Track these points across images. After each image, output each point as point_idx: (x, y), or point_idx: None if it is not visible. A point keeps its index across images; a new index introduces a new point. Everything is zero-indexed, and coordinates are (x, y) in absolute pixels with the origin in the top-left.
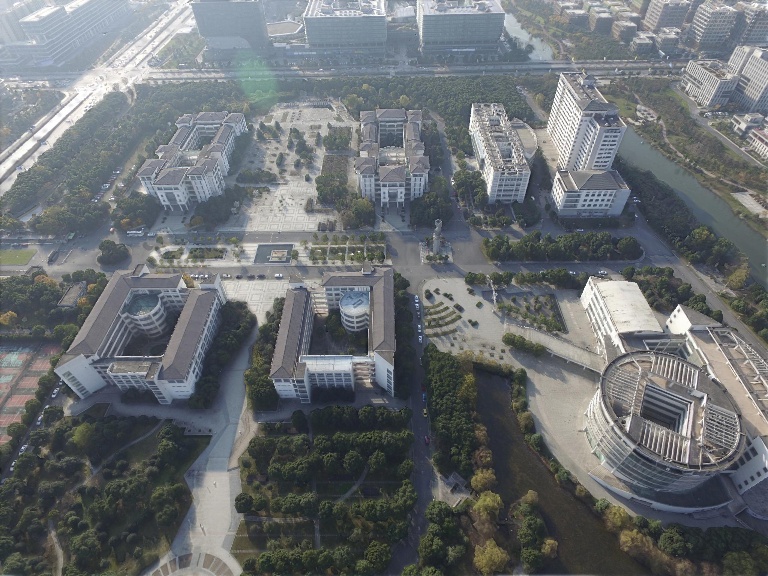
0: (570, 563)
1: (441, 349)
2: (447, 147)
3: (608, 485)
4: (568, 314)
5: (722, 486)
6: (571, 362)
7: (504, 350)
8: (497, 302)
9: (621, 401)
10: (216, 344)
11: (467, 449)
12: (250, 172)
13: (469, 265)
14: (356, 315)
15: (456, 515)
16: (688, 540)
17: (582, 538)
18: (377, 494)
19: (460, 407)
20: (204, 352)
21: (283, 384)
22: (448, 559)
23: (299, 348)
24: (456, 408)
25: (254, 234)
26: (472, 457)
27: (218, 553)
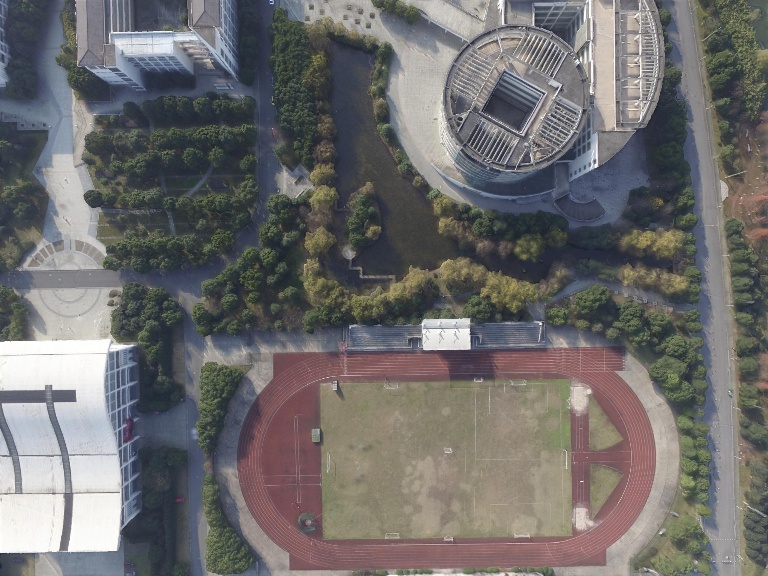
0: (394, 241)
1: (297, 14)
2: None
3: (445, 175)
4: None
5: (552, 176)
6: (449, 31)
7: (373, 14)
8: None
9: (464, 95)
10: (11, 13)
11: (308, 144)
12: None
13: None
14: None
15: (295, 206)
16: (495, 225)
17: (410, 221)
18: (223, 187)
19: (303, 97)
20: (1, 25)
21: (102, 71)
22: (282, 243)
23: (107, 21)
24: (299, 98)
25: None
26: (314, 151)
27: (86, 239)
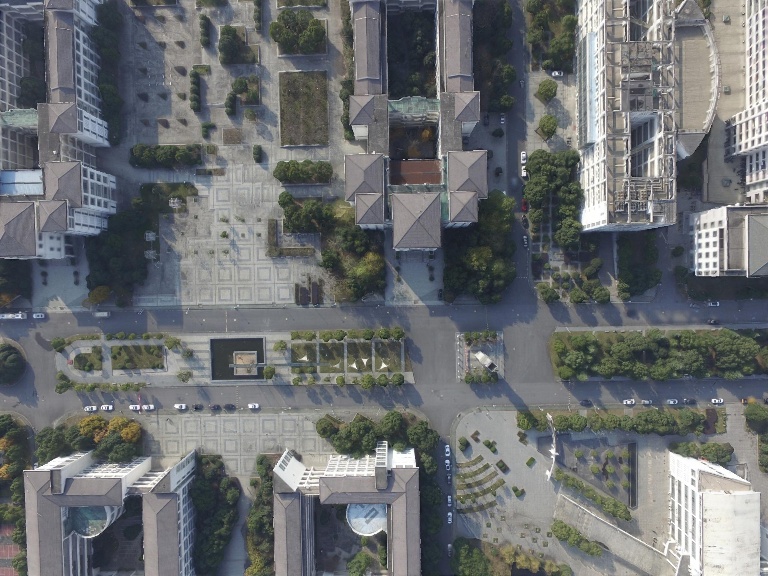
0: None
1: (474, 531)
2: (523, 38)
3: None
4: (645, 478)
5: None
6: None
7: (551, 534)
8: (555, 458)
9: None
10: (201, 547)
11: None
12: (150, 155)
13: (526, 384)
14: (370, 533)
15: None
16: None
17: None
18: None
19: None
20: (190, 555)
21: None
22: None
23: None
24: None
25: (197, 312)
26: None
27: None
